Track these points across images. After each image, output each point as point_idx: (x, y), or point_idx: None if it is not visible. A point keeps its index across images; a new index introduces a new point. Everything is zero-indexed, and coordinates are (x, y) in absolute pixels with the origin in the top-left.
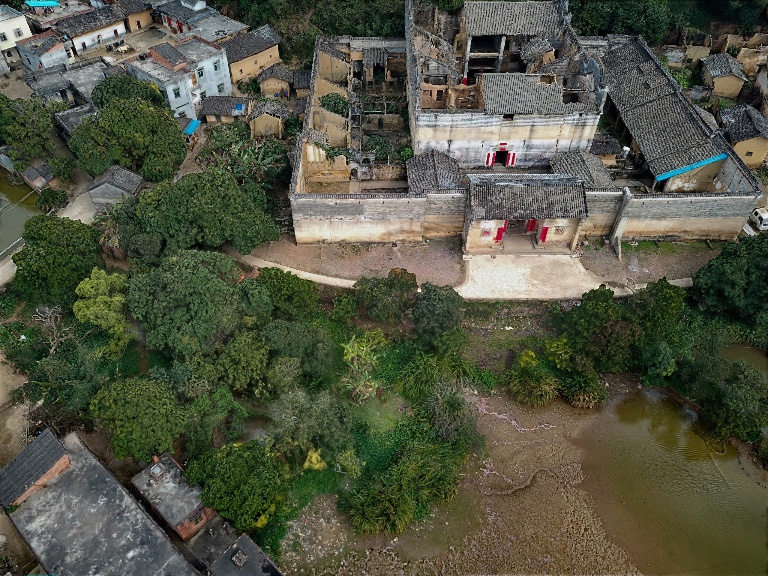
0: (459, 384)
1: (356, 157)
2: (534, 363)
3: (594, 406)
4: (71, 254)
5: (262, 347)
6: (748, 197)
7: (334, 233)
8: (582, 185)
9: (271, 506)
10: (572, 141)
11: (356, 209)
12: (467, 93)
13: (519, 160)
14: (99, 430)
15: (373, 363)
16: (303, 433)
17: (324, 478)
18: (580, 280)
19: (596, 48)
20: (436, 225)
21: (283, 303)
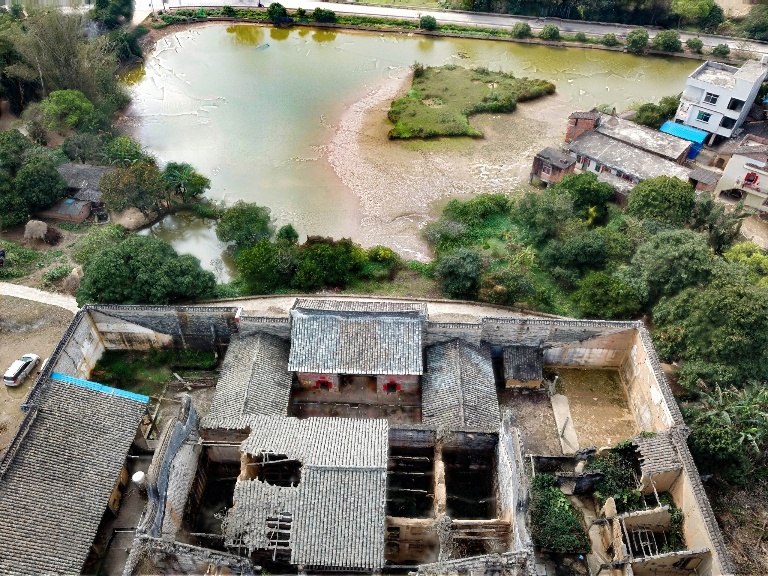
0: None
1: None
2: (381, 248)
3: None
4: None
5: None
6: None
7: None
8: None
9: None
10: None
11: None
12: None
13: None
14: None
15: None
16: None
17: None
18: None
19: None
20: None
21: None
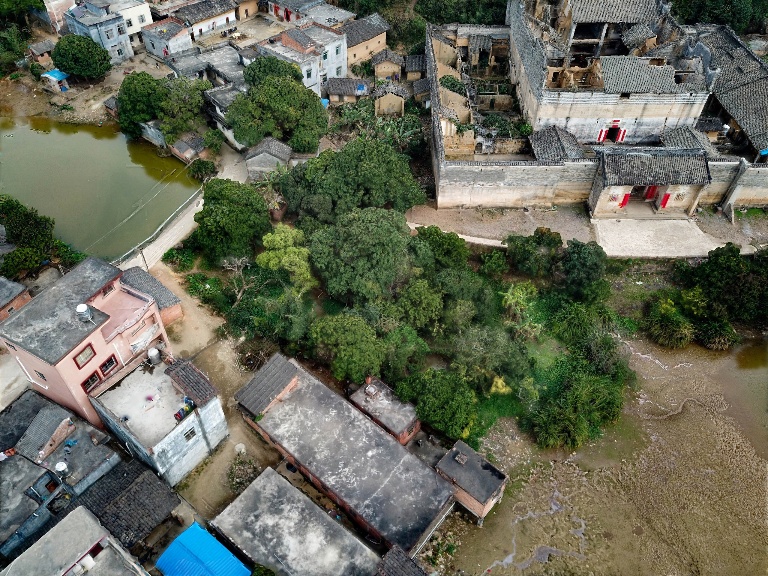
0: (604, 329)
1: None
2: (674, 309)
3: (728, 348)
4: (250, 213)
5: (438, 292)
6: None
7: (473, 198)
8: (704, 155)
9: (470, 421)
10: (680, 119)
11: (498, 176)
12: (581, 75)
13: (628, 136)
14: (321, 355)
15: (531, 308)
16: (491, 361)
17: (502, 403)
18: (700, 241)
19: None
20: (565, 192)
21: (444, 257)
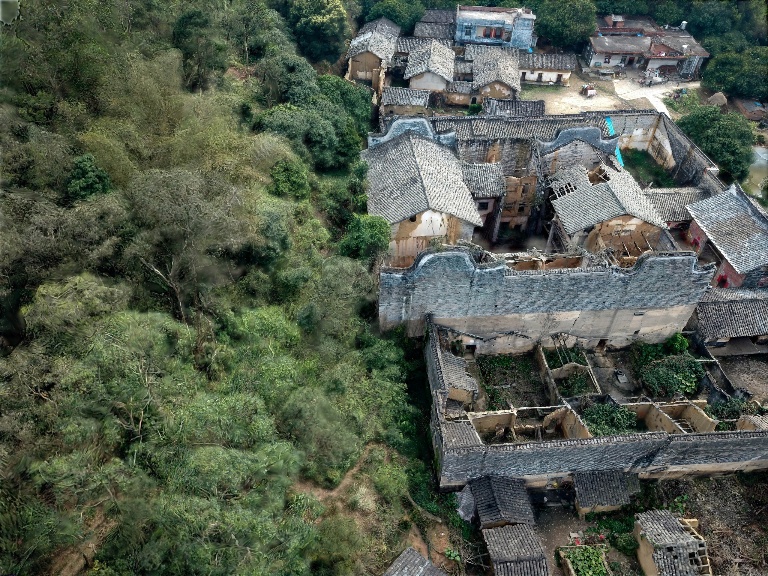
0: None
1: None
2: None
3: None
4: None
5: None
6: None
7: None
8: None
9: None
10: None
11: None
12: None
13: None
14: None
15: None
16: None
17: None
18: None
19: None
20: None
21: None
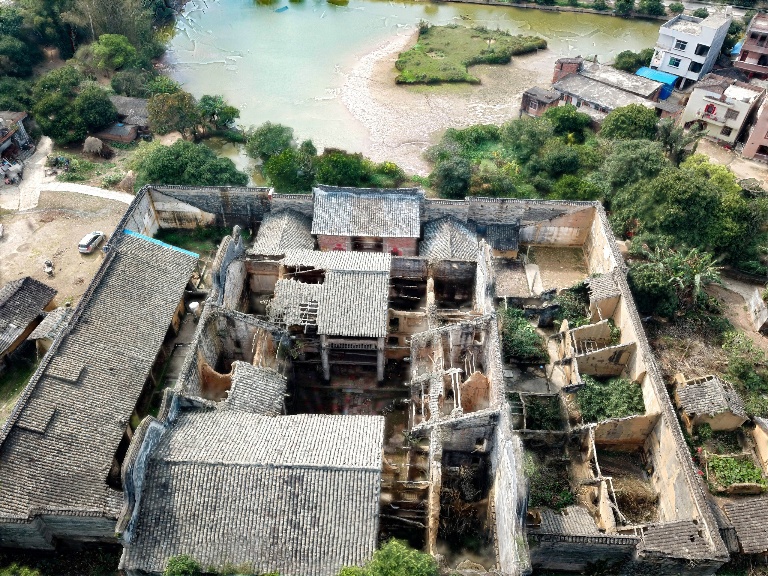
0: None
1: None
2: None
3: None
4: None
5: None
6: None
7: None
8: None
9: None
10: None
11: None
12: None
13: None
14: None
15: None
16: None
17: None
18: None
19: None
20: None
21: None
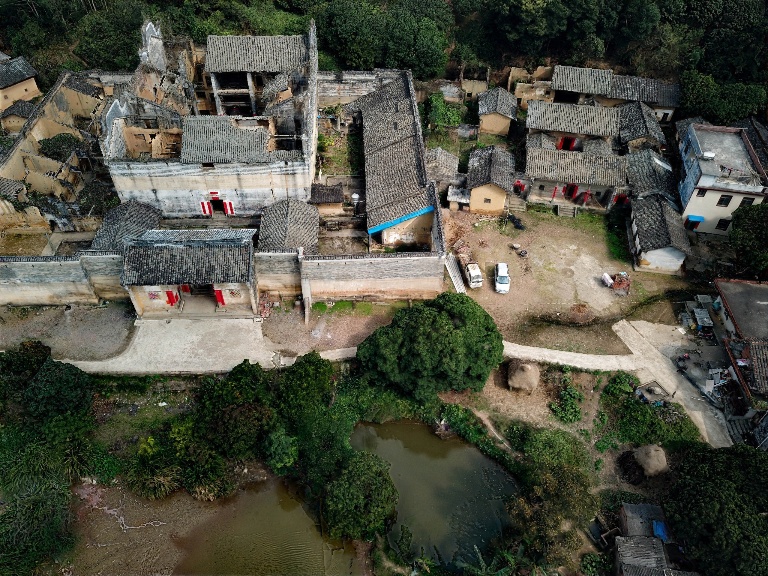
0: (74, 474)
1: (58, 207)
2: (149, 452)
3: (214, 499)
4: None
5: None
6: (431, 257)
7: None
8: (248, 246)
9: None
10: (288, 190)
11: (6, 272)
12: None
13: (238, 209)
14: None
15: None
16: None
17: None
18: (251, 348)
19: (365, 83)
20: (110, 286)
21: None
